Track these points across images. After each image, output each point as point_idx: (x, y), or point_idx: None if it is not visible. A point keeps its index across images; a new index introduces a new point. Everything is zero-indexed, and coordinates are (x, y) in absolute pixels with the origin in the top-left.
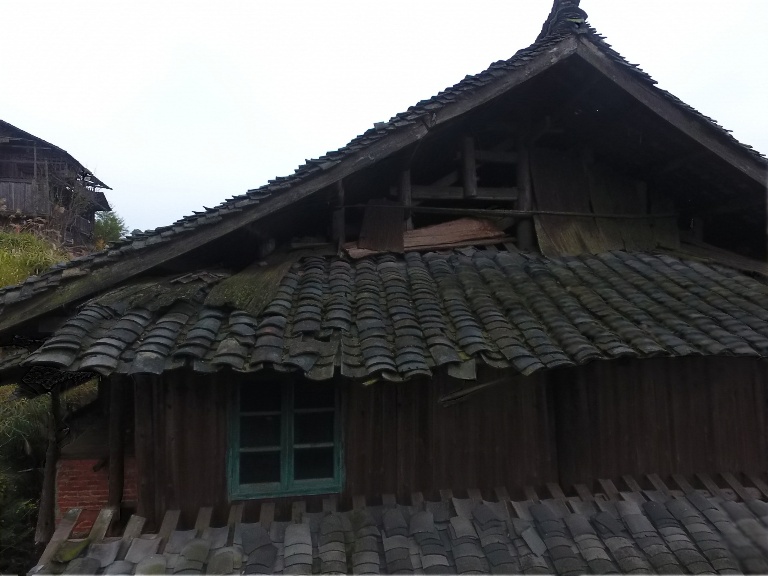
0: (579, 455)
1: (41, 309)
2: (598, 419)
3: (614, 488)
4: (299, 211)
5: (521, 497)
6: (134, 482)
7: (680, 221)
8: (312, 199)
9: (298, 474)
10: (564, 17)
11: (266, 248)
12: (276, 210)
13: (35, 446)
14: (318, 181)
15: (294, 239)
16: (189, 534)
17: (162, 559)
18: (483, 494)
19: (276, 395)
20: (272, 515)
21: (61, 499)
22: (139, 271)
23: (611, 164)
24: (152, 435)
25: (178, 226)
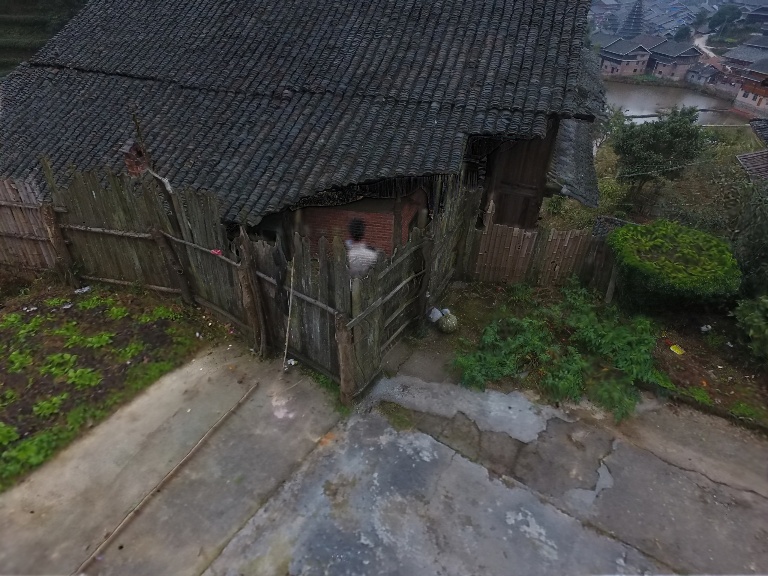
0: None
1: None
2: None
3: None
4: None
5: None
6: None
7: None
8: None
9: None
10: None
11: None
12: None
13: None
14: None
15: None
16: (559, 168)
17: None
18: None
19: None
20: None
21: None
22: None
23: None
24: None
25: None
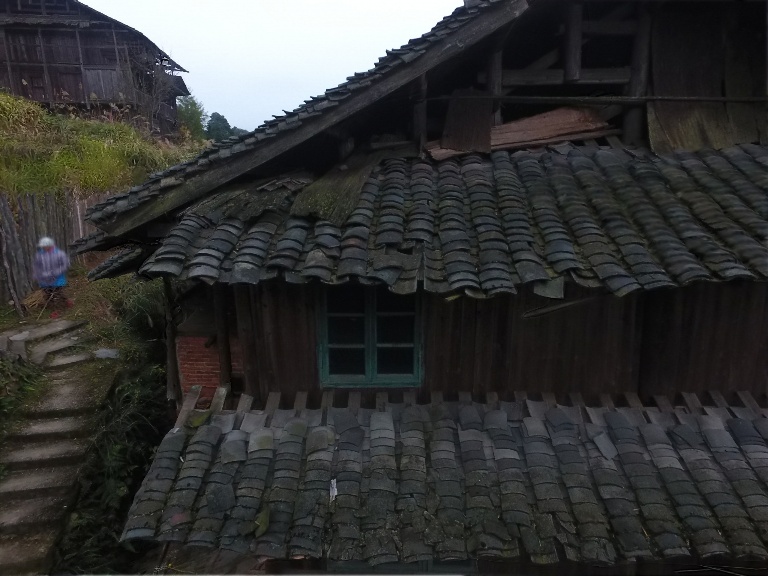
0: (664, 368)
1: (147, 217)
2: (691, 334)
3: (698, 402)
4: (378, 107)
5: (596, 403)
6: (239, 358)
7: None
8: (393, 95)
9: (381, 369)
10: None
11: (345, 148)
12: (356, 112)
13: (156, 320)
14: (400, 76)
15: (373, 138)
16: (289, 413)
17: (269, 432)
18: (557, 398)
19: (360, 299)
20: (359, 402)
21: (183, 367)
22: (228, 180)
23: (761, 30)
24: (252, 330)
25: (260, 132)
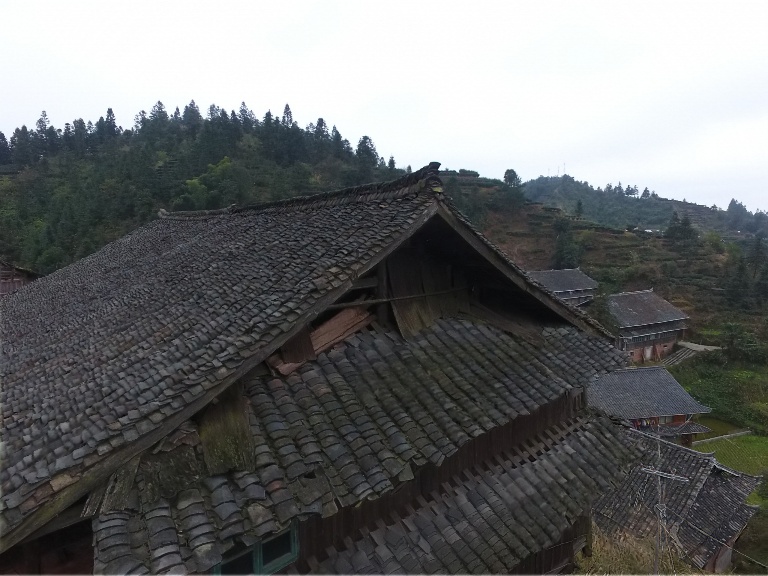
0: (432, 474)
1: (31, 528)
2: None
3: (450, 487)
4: None
5: (405, 514)
6: None
7: (469, 290)
8: None
9: (265, 560)
10: (430, 186)
11: None
12: None
13: None
14: (279, 339)
15: None
16: None
17: None
18: (385, 521)
19: None
20: None
21: None
22: None
23: None
24: None
25: (164, 407)
